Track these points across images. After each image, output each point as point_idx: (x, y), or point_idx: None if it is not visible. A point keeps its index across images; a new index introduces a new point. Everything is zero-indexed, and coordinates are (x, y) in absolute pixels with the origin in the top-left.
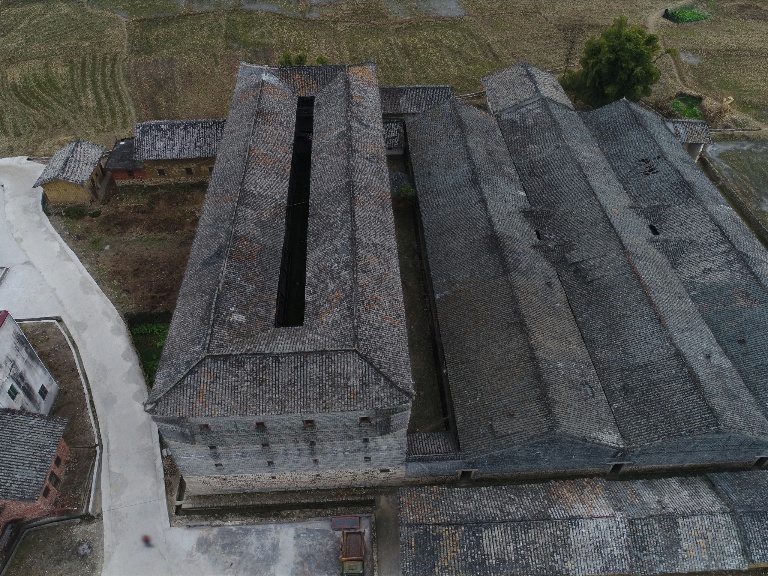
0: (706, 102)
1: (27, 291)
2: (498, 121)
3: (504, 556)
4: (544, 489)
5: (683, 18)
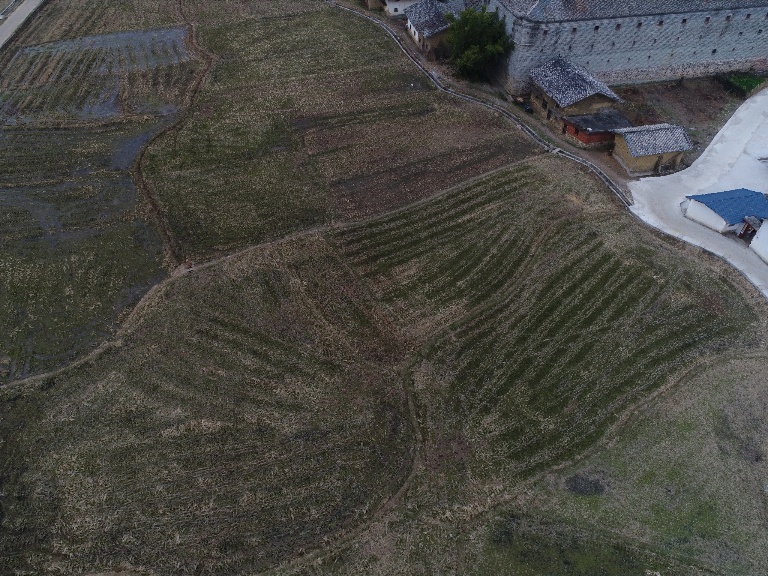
0: None
1: (766, 143)
2: None
3: None
4: None
5: None
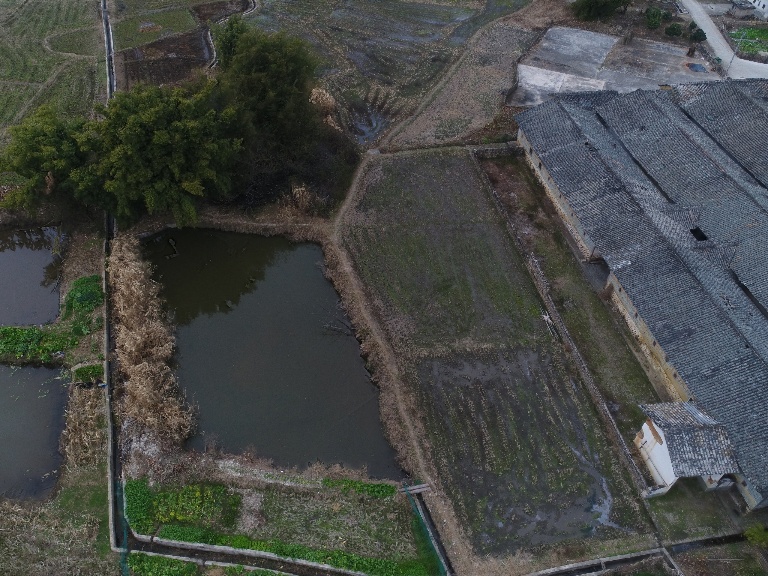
0: None
1: None
2: None
3: None
4: None
5: None
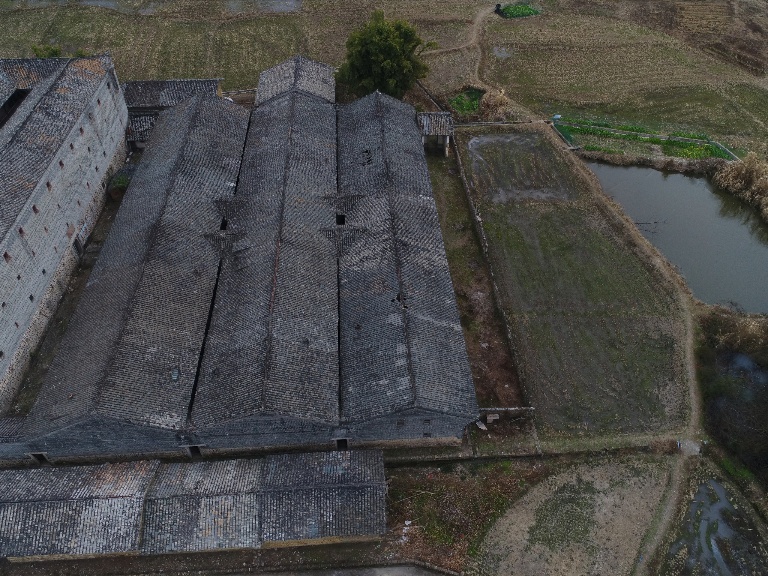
0: (486, 95)
1: None
2: (252, 114)
3: (9, 535)
4: (91, 471)
5: (513, 13)
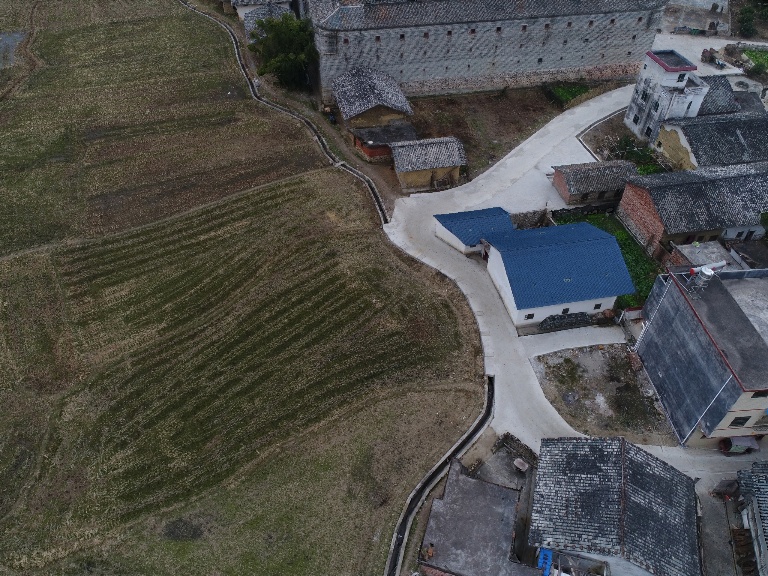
0: None
1: (564, 157)
2: None
3: None
4: None
5: None
